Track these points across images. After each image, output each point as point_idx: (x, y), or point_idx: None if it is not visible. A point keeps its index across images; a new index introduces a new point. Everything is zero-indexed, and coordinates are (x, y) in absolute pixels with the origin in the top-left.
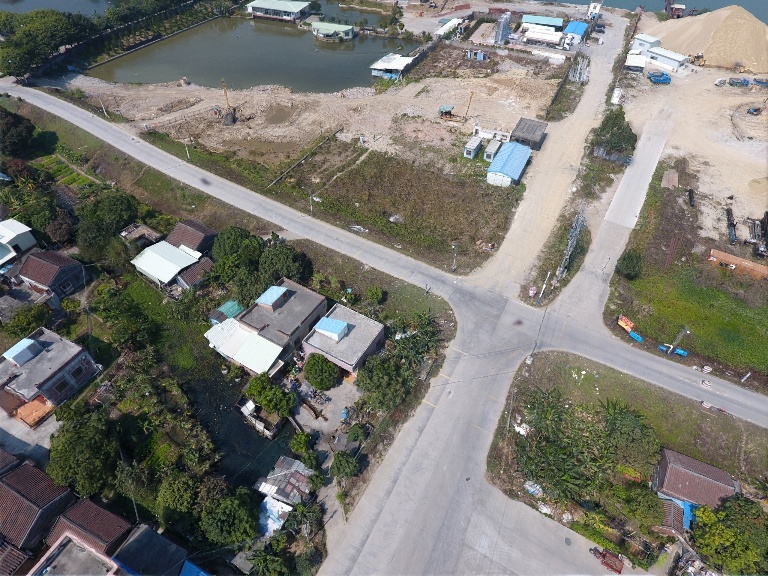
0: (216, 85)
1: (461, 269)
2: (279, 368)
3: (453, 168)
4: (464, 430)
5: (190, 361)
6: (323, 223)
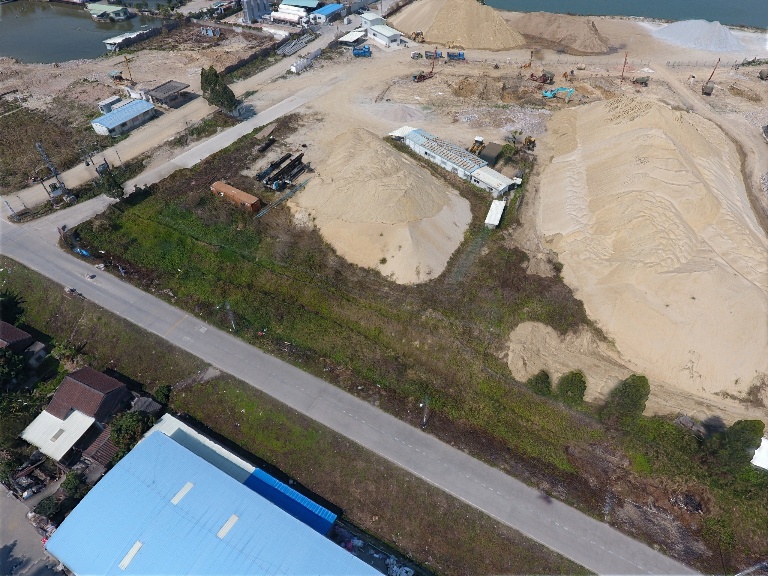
0: None
1: None
2: None
3: (82, 122)
4: None
5: None
6: None
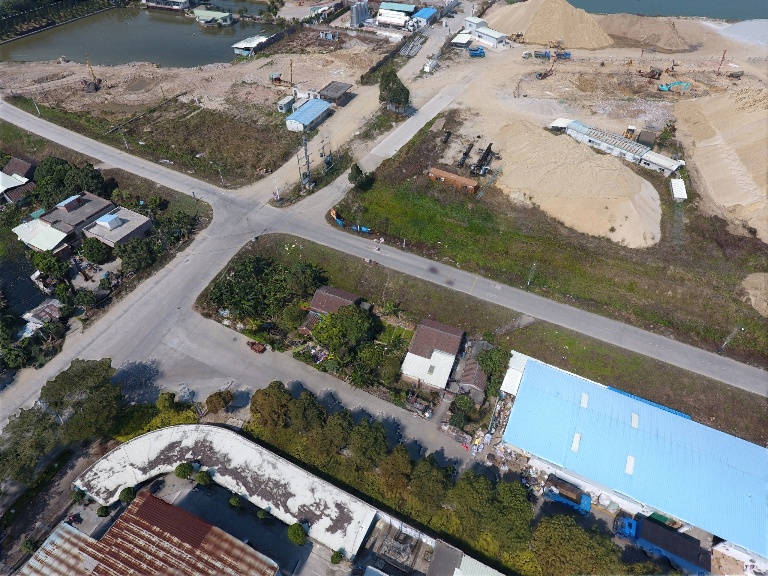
0: (92, 62)
1: (233, 185)
2: (63, 248)
3: (266, 120)
4: (189, 281)
5: (3, 251)
6: (136, 157)
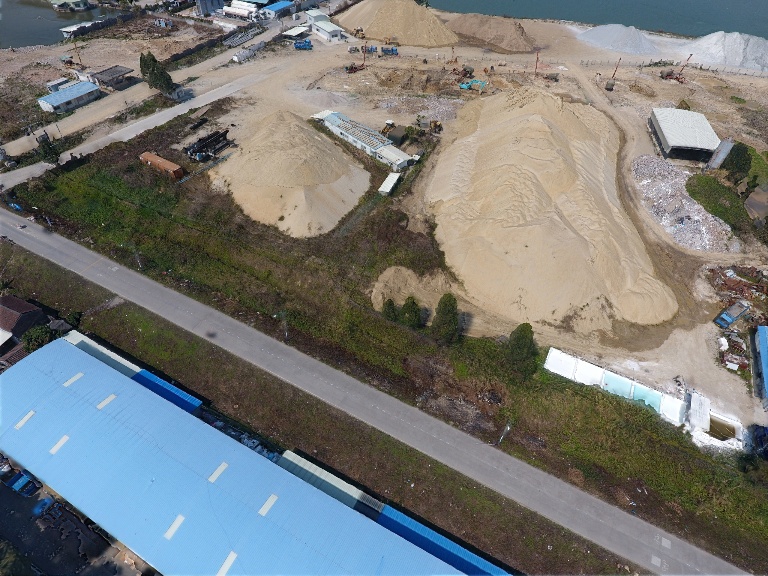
0: None
1: None
2: None
3: (31, 100)
4: None
5: None
6: None
